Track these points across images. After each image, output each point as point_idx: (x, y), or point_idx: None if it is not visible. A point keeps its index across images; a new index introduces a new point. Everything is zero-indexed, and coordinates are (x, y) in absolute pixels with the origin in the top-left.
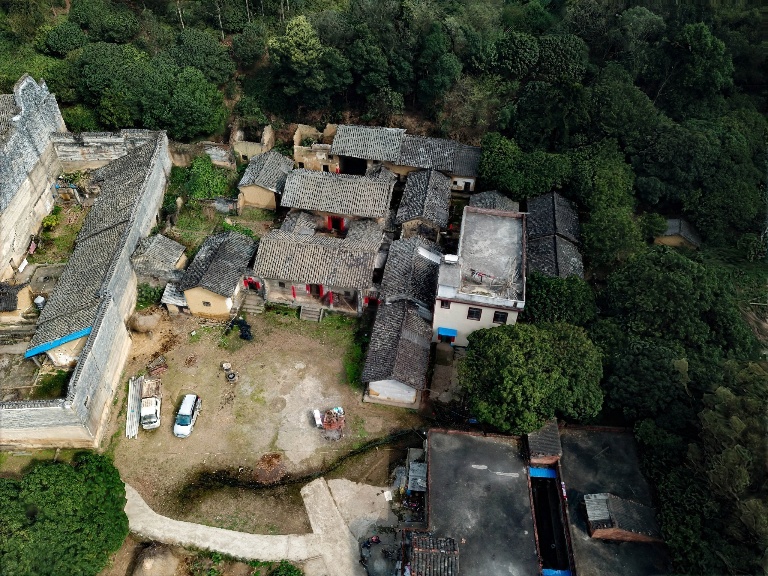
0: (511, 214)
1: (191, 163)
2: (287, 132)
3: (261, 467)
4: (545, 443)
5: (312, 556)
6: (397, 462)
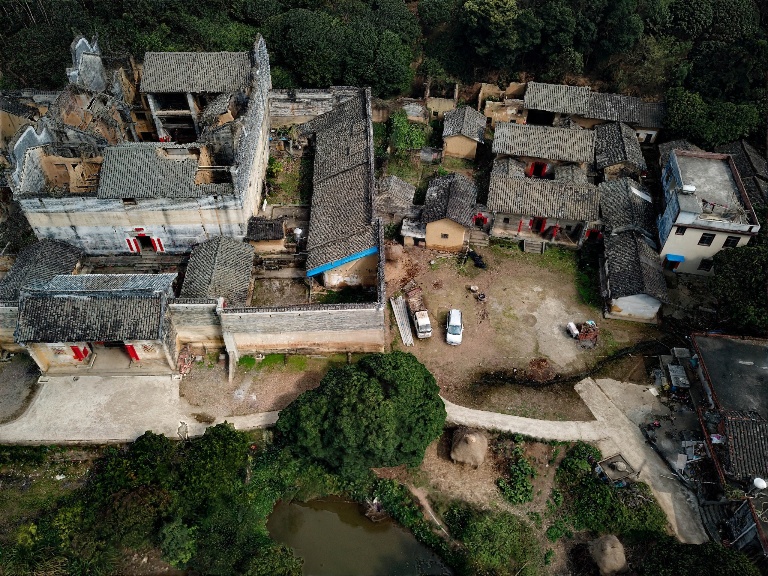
0: (717, 156)
1: (390, 118)
2: (470, 91)
3: (533, 369)
4: None
5: (603, 438)
6: (652, 366)
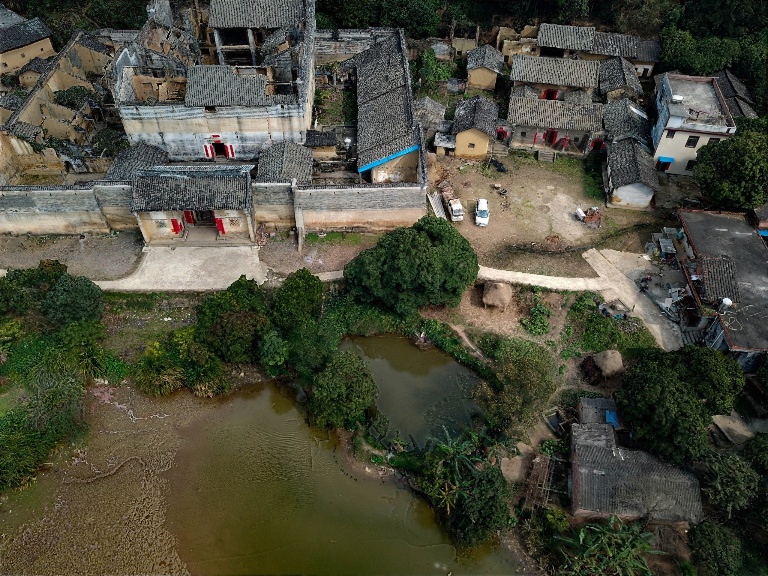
0: (703, 79)
1: (420, 55)
2: (489, 34)
3: (548, 242)
4: None
5: (605, 289)
6: (646, 240)
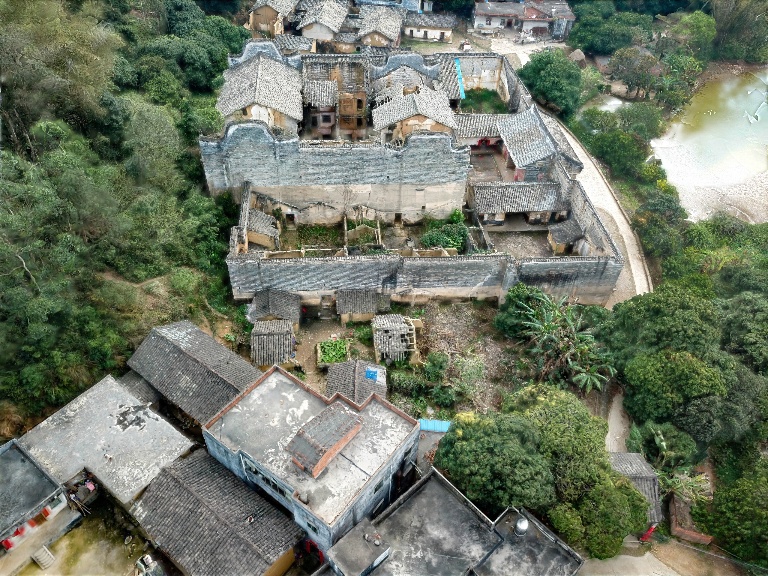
0: None
1: None
2: None
3: None
4: None
5: None
6: (479, 38)
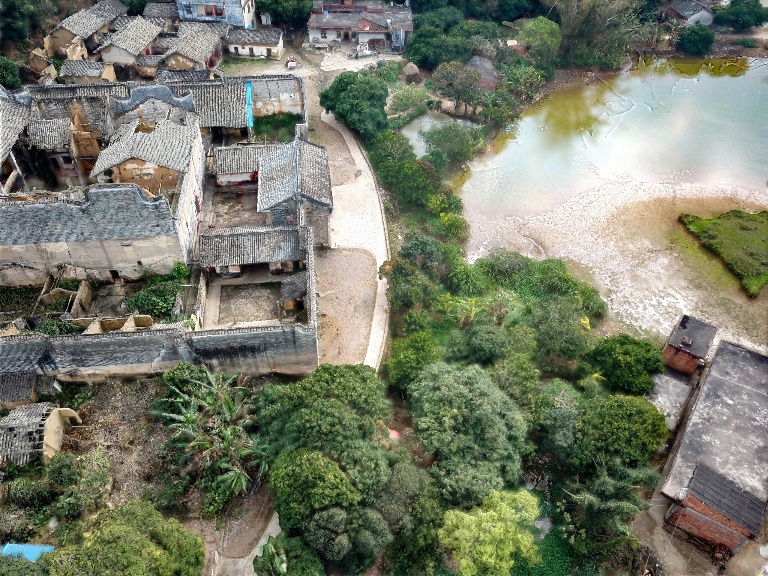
0: None
1: None
2: None
3: (316, 80)
4: (317, 4)
5: None
6: (313, 53)
